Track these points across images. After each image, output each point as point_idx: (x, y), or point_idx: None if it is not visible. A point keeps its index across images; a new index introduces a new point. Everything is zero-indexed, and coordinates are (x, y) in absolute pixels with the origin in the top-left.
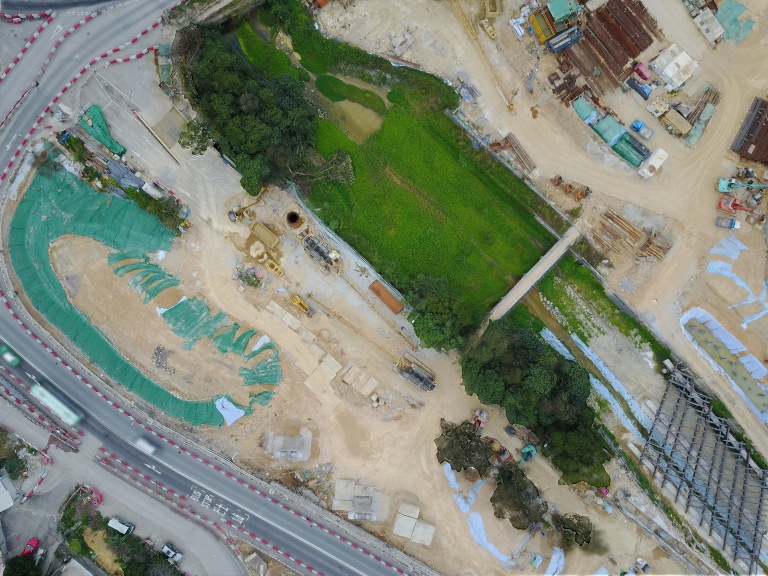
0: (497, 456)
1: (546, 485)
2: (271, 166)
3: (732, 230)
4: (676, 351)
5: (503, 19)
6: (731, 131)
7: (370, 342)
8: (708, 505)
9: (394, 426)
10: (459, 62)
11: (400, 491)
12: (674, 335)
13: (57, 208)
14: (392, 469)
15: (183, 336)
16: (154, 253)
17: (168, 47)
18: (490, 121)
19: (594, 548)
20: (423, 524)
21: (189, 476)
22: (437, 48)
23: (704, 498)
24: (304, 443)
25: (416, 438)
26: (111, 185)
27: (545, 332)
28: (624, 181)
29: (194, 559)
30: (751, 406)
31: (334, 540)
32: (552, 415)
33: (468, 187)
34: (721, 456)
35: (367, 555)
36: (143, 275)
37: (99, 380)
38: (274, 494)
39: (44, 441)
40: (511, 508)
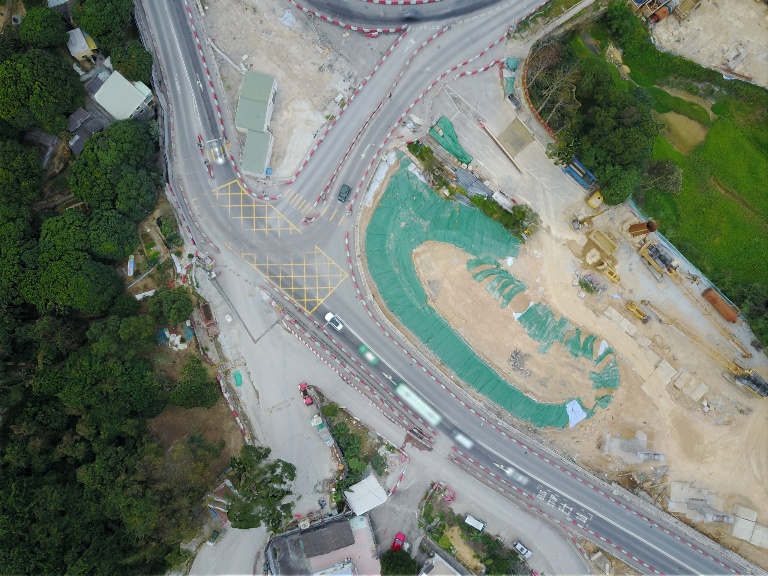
0: None
1: None
2: None
3: None
4: None
5: None
6: None
7: (707, 348)
8: None
9: (725, 431)
10: None
11: (733, 495)
12: None
13: (415, 215)
14: (725, 473)
15: (538, 340)
16: (504, 259)
17: (517, 60)
18: None
19: None
20: (762, 527)
21: (535, 476)
22: None
23: None
24: None
25: (746, 443)
26: (458, 193)
27: None
28: None
29: (541, 556)
30: None
31: (673, 541)
32: None
33: None
34: None
35: (706, 556)
36: (498, 280)
37: (451, 381)
38: (616, 495)
39: (401, 439)
40: None
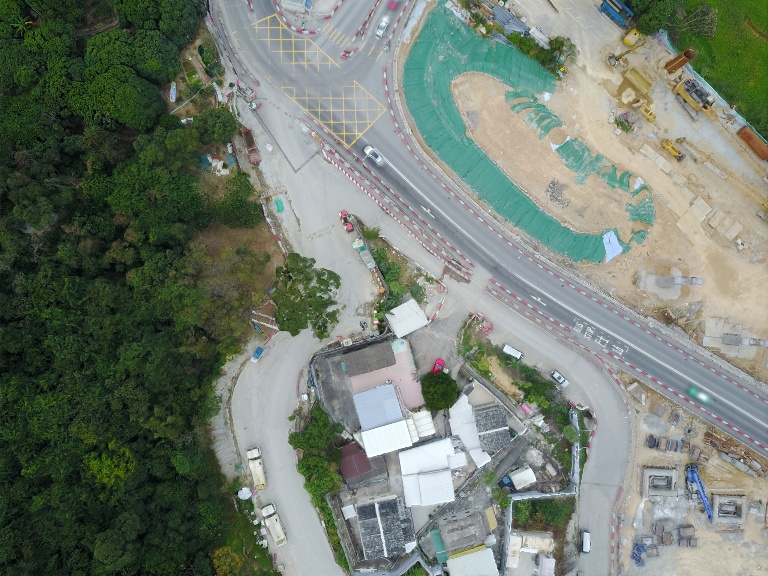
0: None
1: None
2: None
3: None
4: None
5: None
6: None
7: (742, 184)
8: None
9: (759, 268)
10: None
11: (767, 330)
12: None
13: (453, 49)
14: (759, 309)
15: (575, 171)
16: (541, 94)
17: None
18: None
19: None
20: None
21: (572, 308)
22: None
23: None
24: None
25: None
26: (495, 31)
27: None
28: None
29: (578, 387)
30: None
31: (708, 373)
32: None
33: None
34: None
35: (740, 388)
36: (535, 113)
37: (488, 215)
38: (652, 328)
39: (439, 271)
40: None
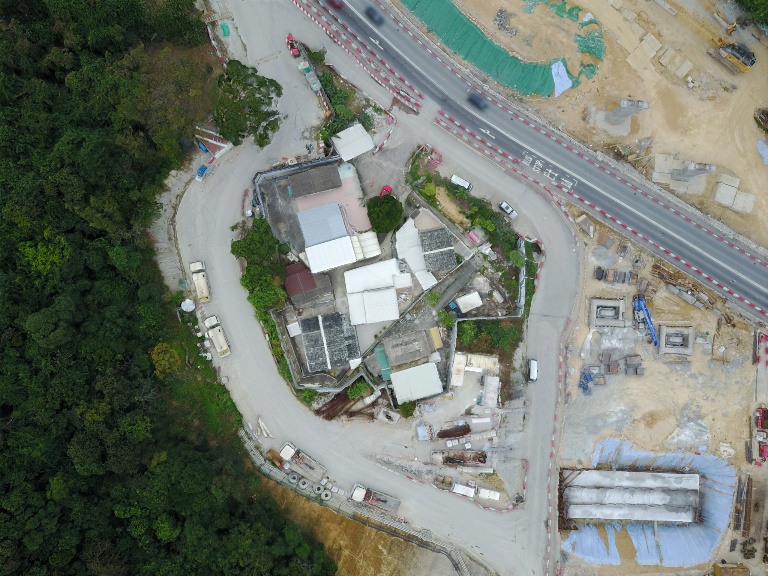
0: None
1: None
2: None
3: None
4: None
5: None
6: None
7: (692, 19)
8: None
9: (709, 106)
10: None
11: None
12: None
13: None
14: (709, 145)
15: None
16: None
17: None
18: None
19: None
20: (744, 192)
21: (521, 142)
22: None
23: None
24: (625, 118)
25: (730, 118)
26: None
27: None
28: None
29: (526, 220)
30: None
31: (657, 207)
32: None
33: None
34: None
35: (689, 222)
36: None
37: (437, 48)
38: (601, 161)
39: (388, 102)
40: None
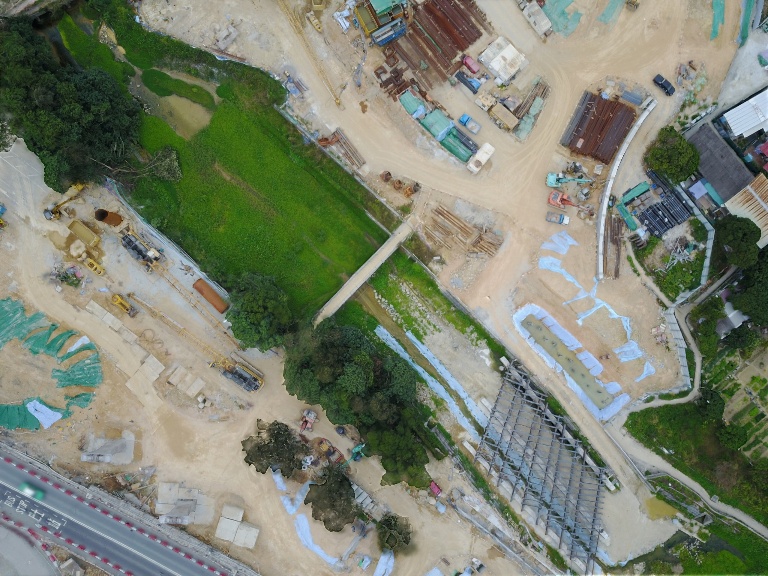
0: (327, 457)
1: (378, 485)
2: (73, 162)
3: (563, 225)
4: (509, 348)
5: (329, 12)
6: (561, 125)
7: (193, 342)
8: (546, 503)
9: (220, 427)
10: (286, 56)
11: (225, 494)
12: (507, 332)
13: None
14: (217, 471)
15: None
16: None
17: None
18: (318, 116)
19: (427, 549)
20: (246, 527)
21: (3, 481)
22: (262, 41)
23: (540, 496)
24: (126, 446)
25: (244, 439)
26: None
27: (380, 330)
28: (454, 176)
29: (8, 566)
30: (587, 403)
31: (155, 544)
32: (372, 415)
33: (299, 183)
34: (557, 454)
35: (189, 559)
36: None
37: None
38: (92, 498)
39: None
40: (322, 510)
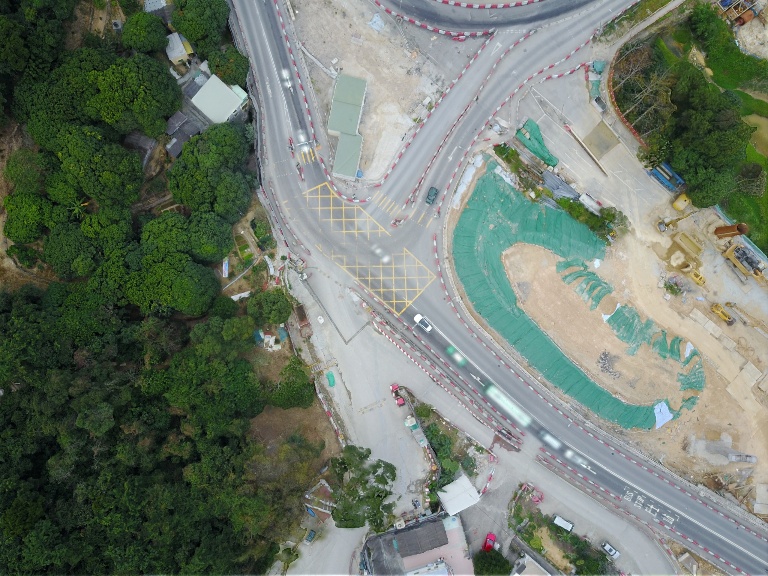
0: None
1: None
2: None
3: None
4: None
5: None
6: None
7: None
8: None
9: None
10: None
11: None
12: None
13: (503, 217)
14: None
15: (627, 342)
16: (591, 261)
17: (603, 63)
18: None
19: None
20: None
21: (622, 477)
22: None
23: None
24: None
25: None
26: (544, 195)
27: None
28: None
29: (628, 557)
30: None
31: (760, 543)
32: None
33: None
34: None
35: None
36: (586, 282)
37: (538, 383)
38: (703, 496)
39: (489, 440)
40: None
